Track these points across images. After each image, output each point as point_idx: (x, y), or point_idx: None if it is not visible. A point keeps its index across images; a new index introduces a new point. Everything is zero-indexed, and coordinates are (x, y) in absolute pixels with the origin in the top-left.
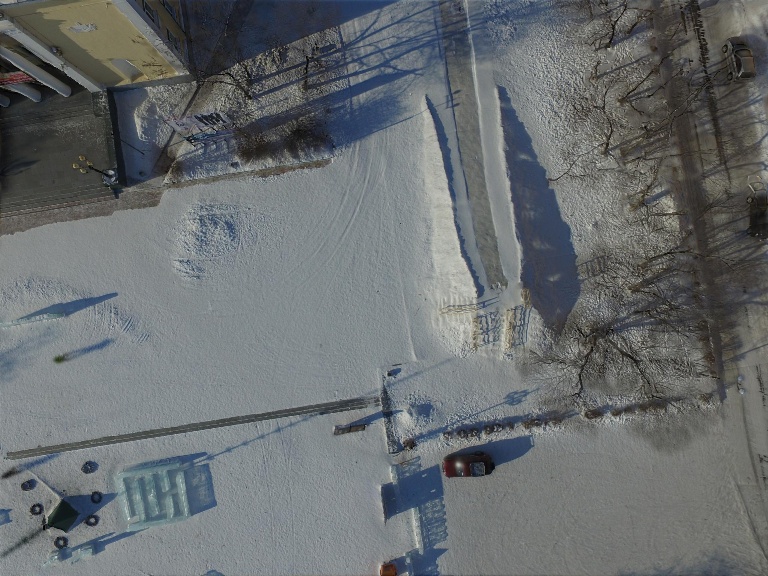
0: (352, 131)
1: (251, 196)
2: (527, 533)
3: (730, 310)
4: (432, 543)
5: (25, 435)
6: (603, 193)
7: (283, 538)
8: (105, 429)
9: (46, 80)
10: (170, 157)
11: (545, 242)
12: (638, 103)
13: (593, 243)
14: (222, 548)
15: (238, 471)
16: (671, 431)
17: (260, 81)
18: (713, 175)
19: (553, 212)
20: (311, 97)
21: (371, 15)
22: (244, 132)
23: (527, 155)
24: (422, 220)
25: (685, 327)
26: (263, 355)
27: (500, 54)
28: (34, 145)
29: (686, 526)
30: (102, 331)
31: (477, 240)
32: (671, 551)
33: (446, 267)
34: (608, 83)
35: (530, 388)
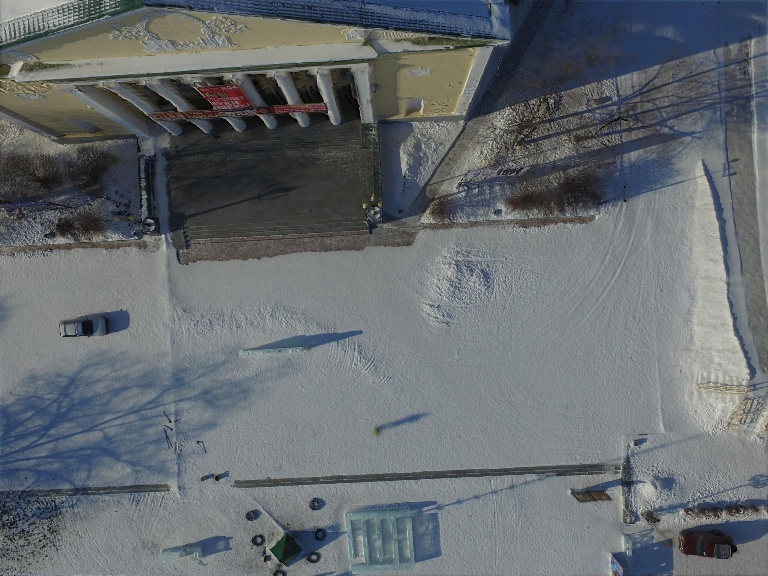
0: (620, 189)
1: (509, 246)
2: None
3: None
4: None
5: (255, 465)
6: None
7: None
8: (337, 467)
9: (334, 111)
10: (429, 196)
11: None
12: None
13: None
14: None
15: (467, 523)
16: None
17: None
18: None
19: None
20: (581, 149)
21: (651, 70)
22: None
23: None
24: (685, 290)
25: None
26: (506, 410)
27: None
28: (294, 171)
29: None
30: (343, 368)
31: (749, 319)
32: None
33: (710, 342)
34: None
35: None
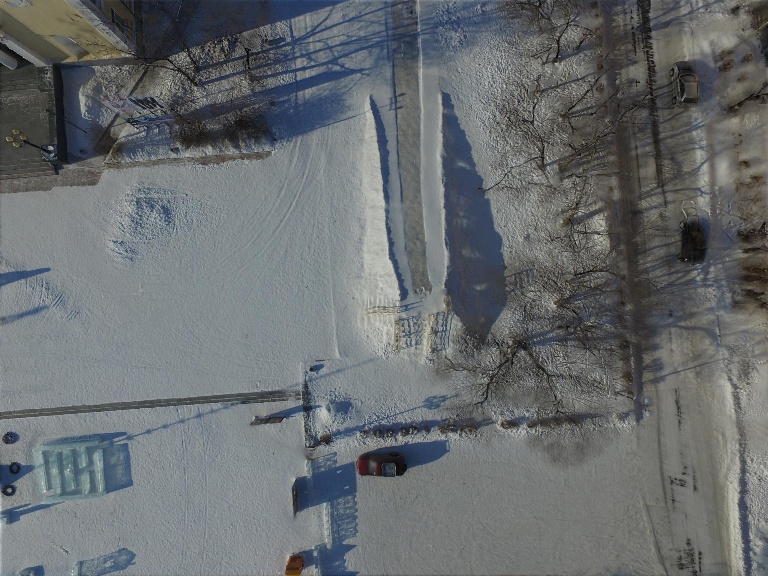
0: (295, 126)
1: (190, 182)
2: (436, 536)
3: (654, 332)
4: (341, 538)
5: None
6: (538, 207)
7: (196, 522)
8: (28, 401)
9: None
10: (113, 137)
11: (476, 251)
12: (580, 120)
13: (523, 255)
14: (135, 527)
15: (156, 453)
16: (585, 447)
17: (207, 69)
18: (649, 197)
19: (487, 222)
20: (257, 89)
21: (323, 11)
22: (187, 118)
23: (465, 163)
24: (356, 219)
25: (607, 346)
26: (189, 341)
27: (448, 60)
28: None
29: (592, 541)
30: (32, 305)
31: (406, 244)
32: (575, 565)
33: (375, 268)
34: (552, 98)
35: (449, 394)
